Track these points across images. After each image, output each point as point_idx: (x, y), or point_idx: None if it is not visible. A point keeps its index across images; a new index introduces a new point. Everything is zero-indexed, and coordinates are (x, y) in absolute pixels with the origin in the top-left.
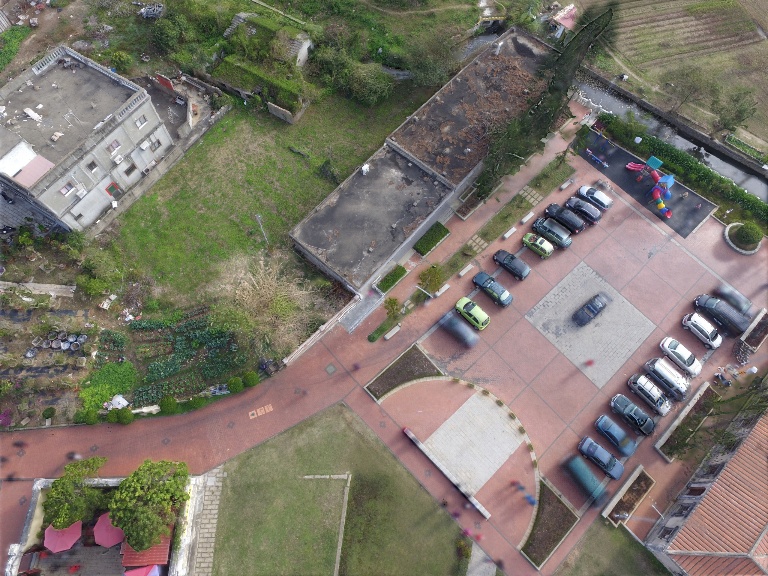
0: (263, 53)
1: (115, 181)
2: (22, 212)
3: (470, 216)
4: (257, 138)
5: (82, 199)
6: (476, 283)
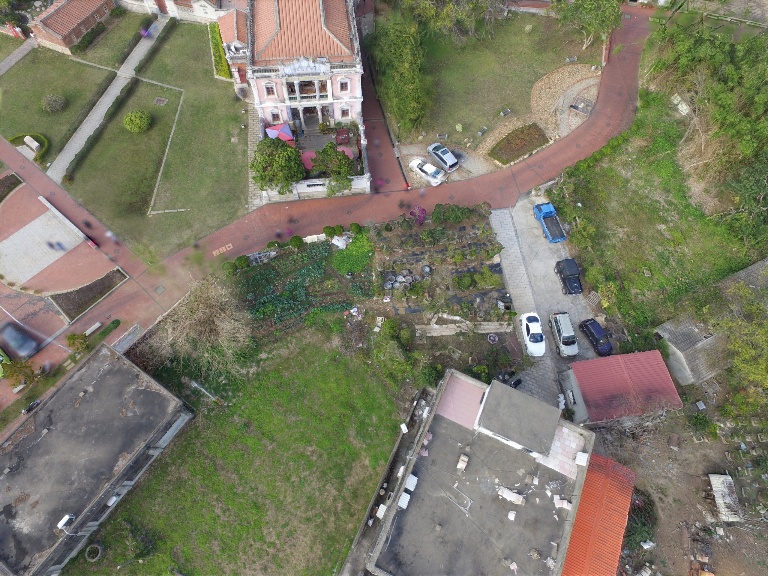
0: None
1: None
2: None
3: None
4: None
5: None
6: None
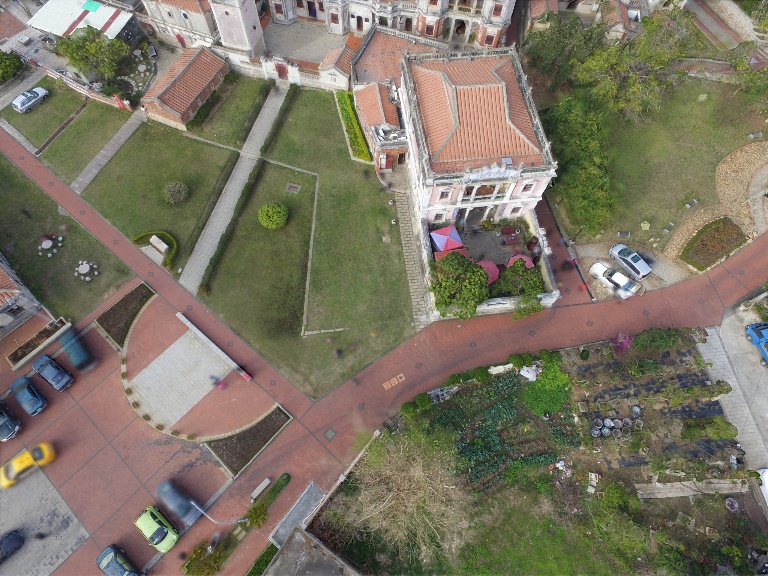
0: None
1: None
2: None
3: None
4: None
5: None
6: None
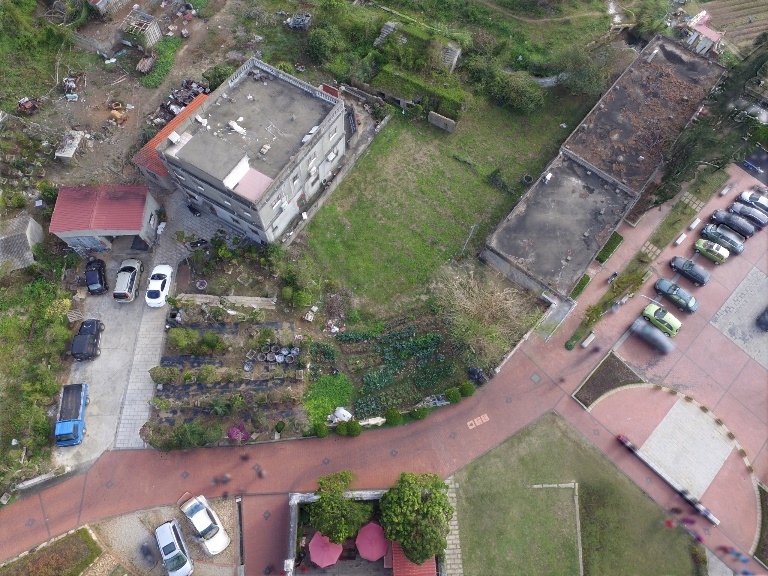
0: (421, 62)
1: (304, 192)
2: (209, 224)
3: (638, 223)
4: (422, 147)
5: (282, 211)
6: (659, 290)
